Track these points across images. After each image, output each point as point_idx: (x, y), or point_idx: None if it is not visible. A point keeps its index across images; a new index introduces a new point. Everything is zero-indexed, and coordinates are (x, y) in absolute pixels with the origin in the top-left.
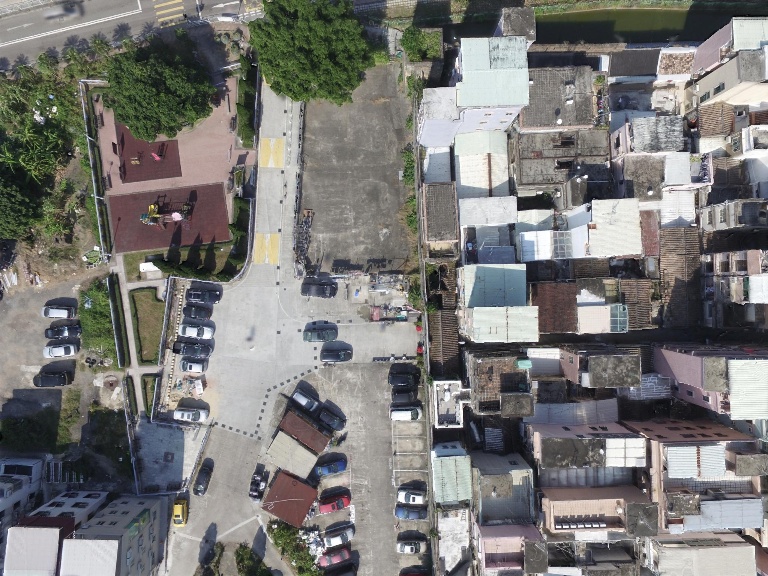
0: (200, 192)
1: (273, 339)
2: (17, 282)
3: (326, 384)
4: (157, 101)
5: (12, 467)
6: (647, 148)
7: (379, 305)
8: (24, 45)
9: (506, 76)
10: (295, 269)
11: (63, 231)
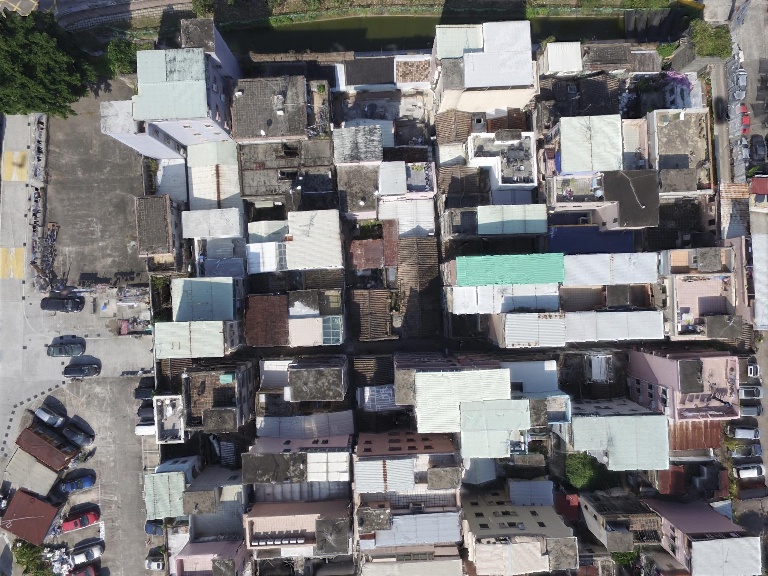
0: None
1: (19, 354)
2: None
3: (74, 399)
4: None
5: None
6: (347, 158)
7: (128, 318)
8: None
9: (183, 88)
10: (35, 284)
11: None
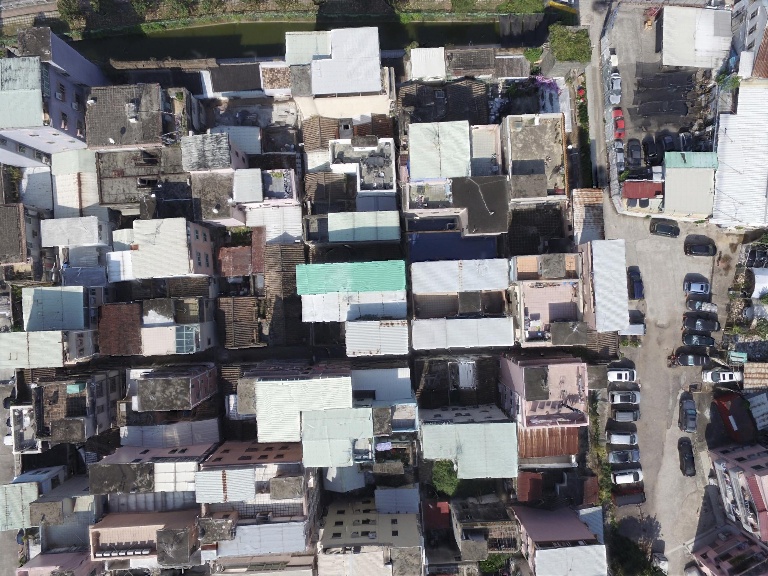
0: None
1: None
2: None
3: None
4: None
5: None
6: (195, 166)
7: None
8: None
9: (19, 97)
10: None
11: None
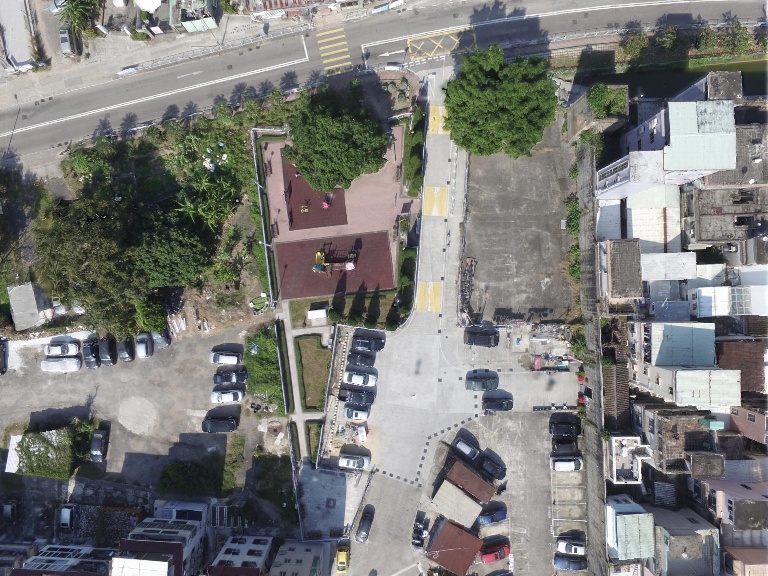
0: (365, 240)
1: (434, 387)
2: (185, 327)
3: (486, 432)
4: (346, 156)
5: (183, 512)
6: None
7: (540, 354)
8: (193, 93)
9: (713, 140)
10: (460, 318)
11: (234, 278)
